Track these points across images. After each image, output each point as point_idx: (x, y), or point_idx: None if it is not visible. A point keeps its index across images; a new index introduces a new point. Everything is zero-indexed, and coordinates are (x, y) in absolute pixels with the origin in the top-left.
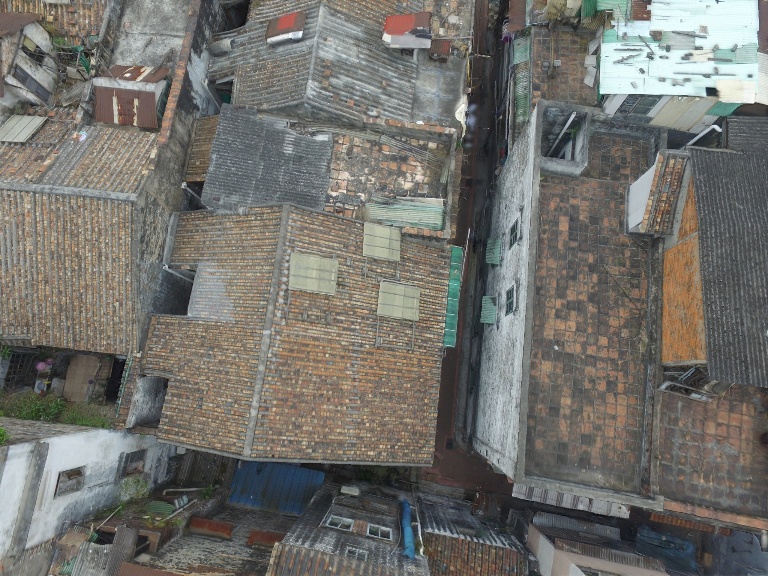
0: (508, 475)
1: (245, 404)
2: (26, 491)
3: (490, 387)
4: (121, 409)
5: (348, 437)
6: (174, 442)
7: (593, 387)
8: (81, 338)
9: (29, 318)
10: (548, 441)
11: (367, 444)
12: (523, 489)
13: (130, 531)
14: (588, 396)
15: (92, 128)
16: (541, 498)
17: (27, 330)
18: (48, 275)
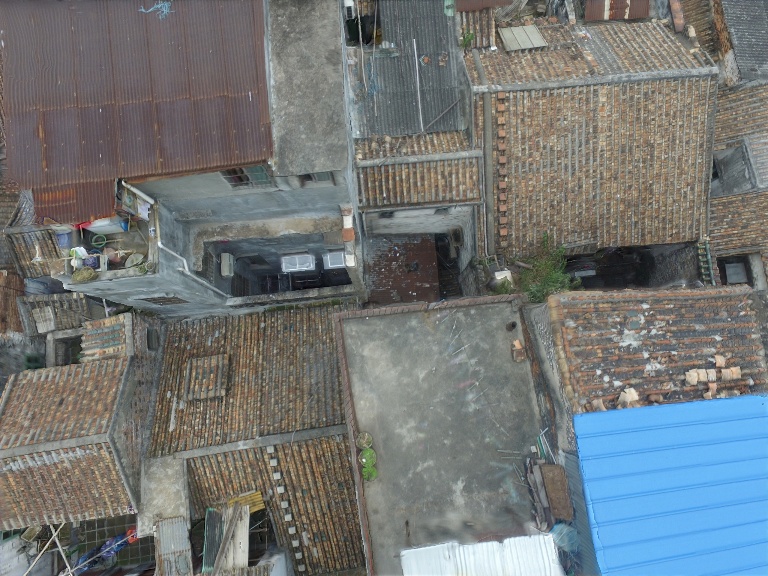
0: None
1: None
2: None
3: None
4: None
5: None
6: None
7: None
8: (648, 232)
9: (597, 220)
10: None
11: None
12: None
13: None
14: None
15: (584, 28)
16: None
17: (591, 234)
18: (618, 170)
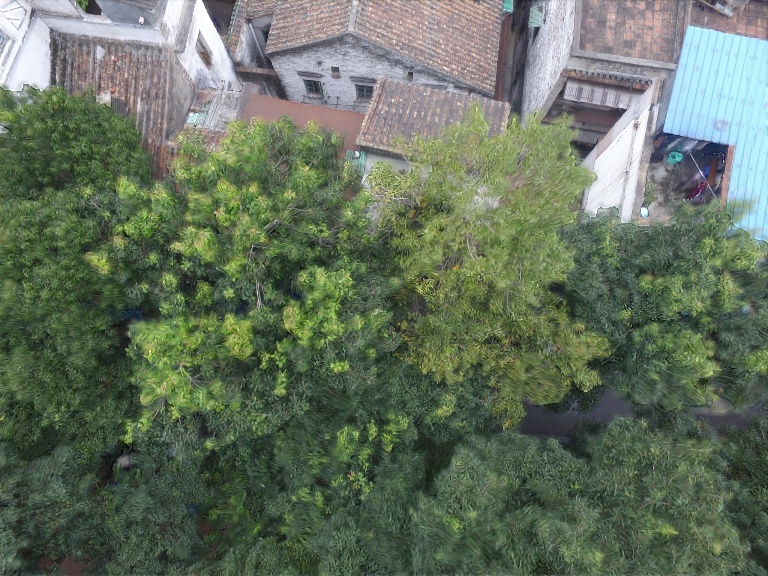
0: (563, 68)
1: (347, 2)
2: (185, 8)
3: (537, 73)
4: (233, 36)
5: (428, 49)
6: (282, 48)
7: (634, 6)
8: None
9: None
10: (596, 45)
11: (443, 60)
12: (573, 92)
13: (255, 85)
14: (630, 12)
15: None
16: (588, 99)
17: None
18: None
